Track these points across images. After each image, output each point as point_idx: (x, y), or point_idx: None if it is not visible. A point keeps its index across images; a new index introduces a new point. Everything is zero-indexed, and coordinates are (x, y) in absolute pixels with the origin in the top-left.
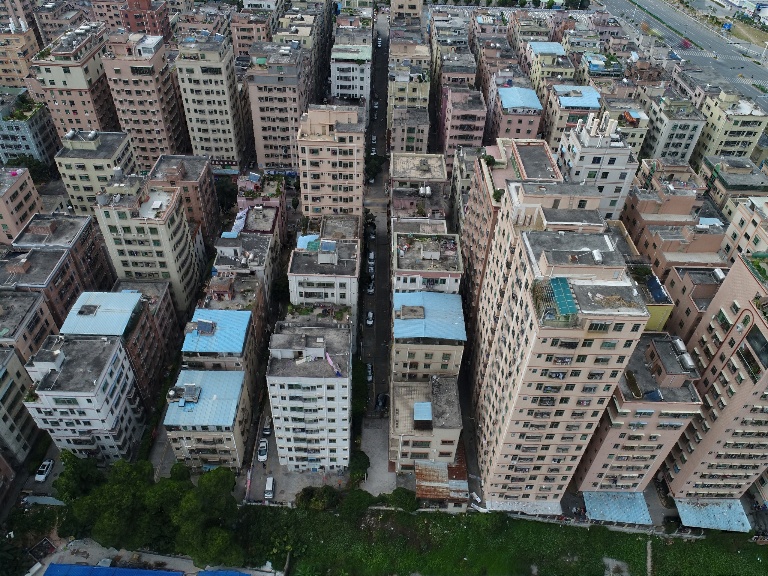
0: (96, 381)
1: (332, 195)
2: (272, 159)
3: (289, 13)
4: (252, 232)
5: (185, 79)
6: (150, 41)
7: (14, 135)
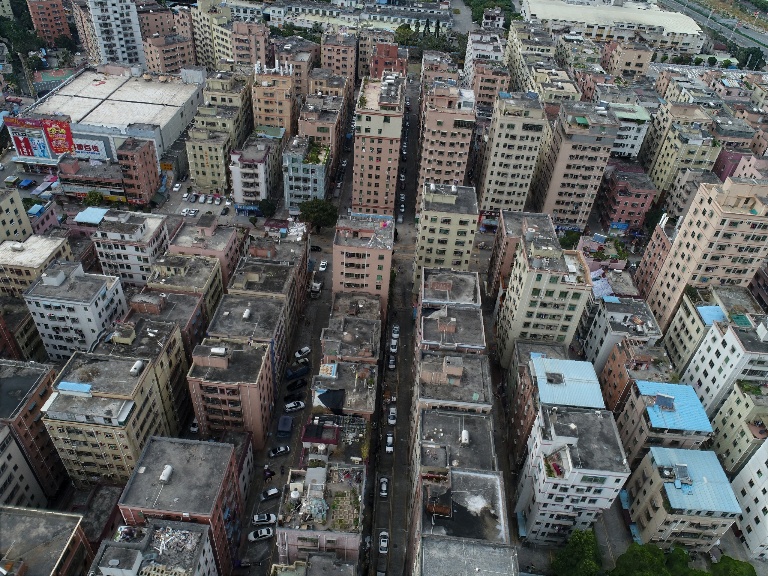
0: (626, 461)
1: (727, 266)
2: (559, 214)
3: (539, 67)
4: (622, 296)
5: (502, 134)
6: (467, 95)
7: (307, 177)
